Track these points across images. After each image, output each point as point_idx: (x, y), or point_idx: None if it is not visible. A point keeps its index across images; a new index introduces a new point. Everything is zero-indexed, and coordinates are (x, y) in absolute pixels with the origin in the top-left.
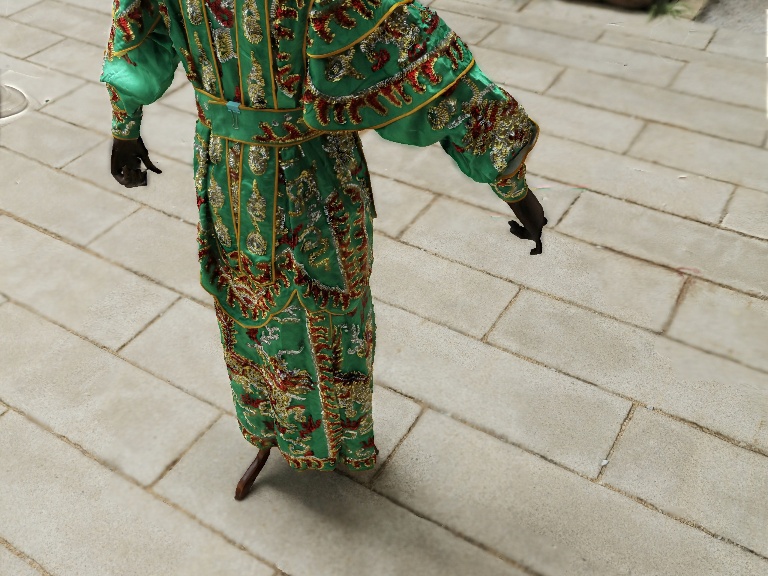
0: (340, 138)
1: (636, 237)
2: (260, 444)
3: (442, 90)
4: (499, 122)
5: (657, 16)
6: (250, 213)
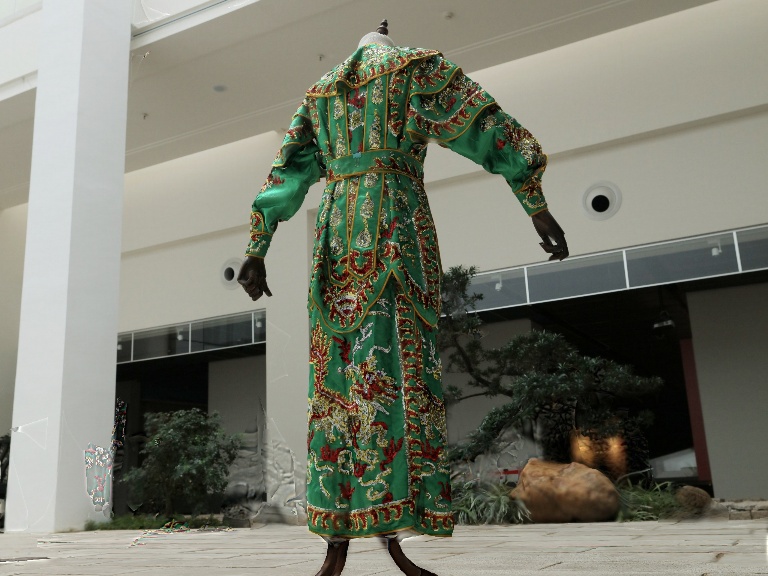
0: (420, 192)
1: (660, 549)
2: (332, 523)
3: (488, 104)
4: (523, 140)
5: (625, 520)
6: (362, 215)
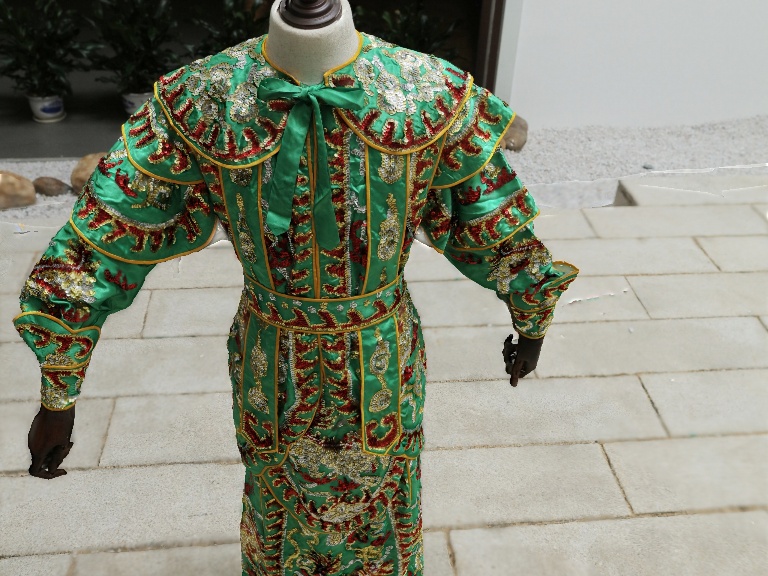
0: None
1: None
2: None
3: None
4: None
5: None
6: None
